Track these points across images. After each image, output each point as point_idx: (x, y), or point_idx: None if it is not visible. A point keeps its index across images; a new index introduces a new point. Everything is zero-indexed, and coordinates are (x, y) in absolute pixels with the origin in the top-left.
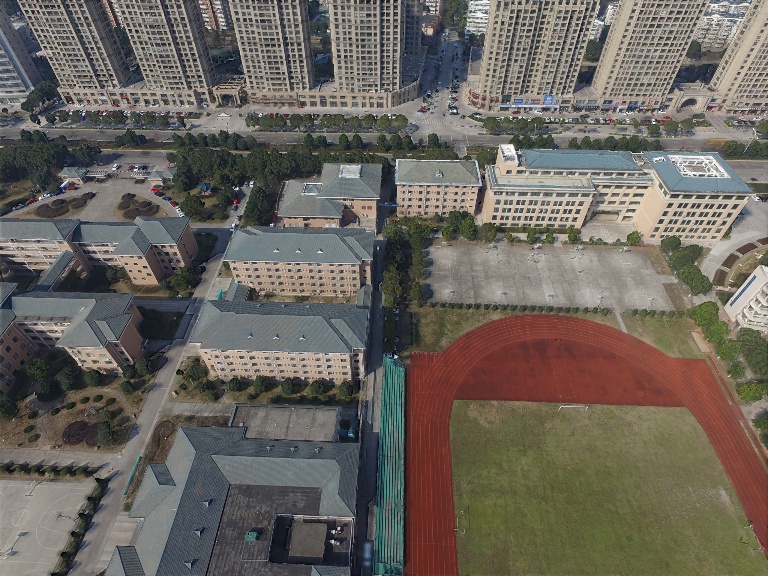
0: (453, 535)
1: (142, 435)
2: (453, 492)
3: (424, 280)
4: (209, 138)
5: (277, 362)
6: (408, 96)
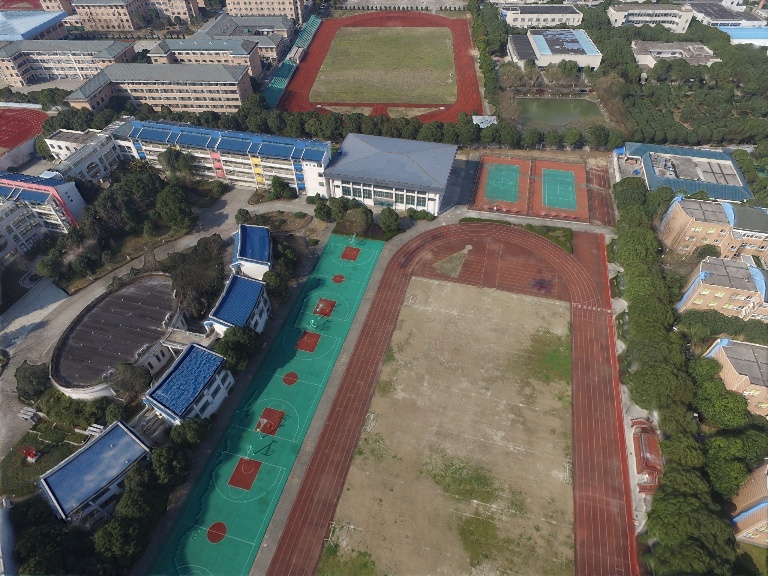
0: None
1: None
2: None
3: (341, 5)
4: None
5: (261, 6)
6: None
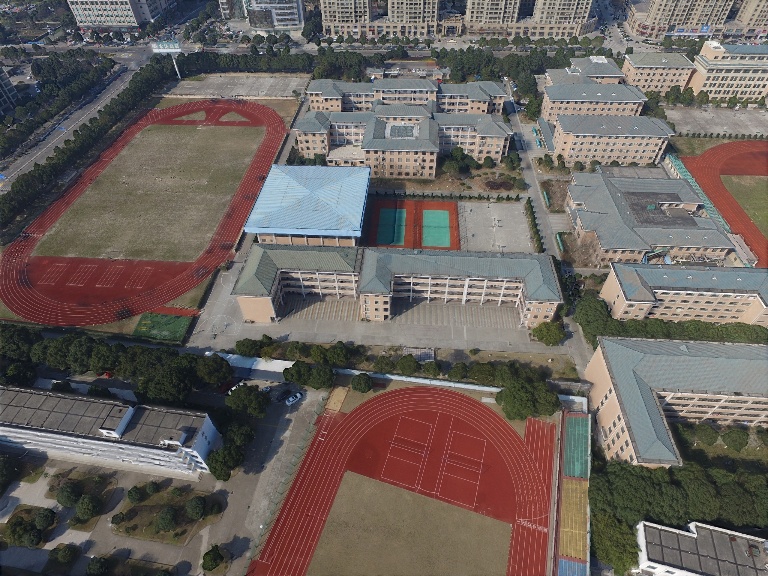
0: (752, 223)
1: (534, 187)
2: (742, 209)
3: None
4: (459, 51)
5: (612, 148)
6: (589, 29)
